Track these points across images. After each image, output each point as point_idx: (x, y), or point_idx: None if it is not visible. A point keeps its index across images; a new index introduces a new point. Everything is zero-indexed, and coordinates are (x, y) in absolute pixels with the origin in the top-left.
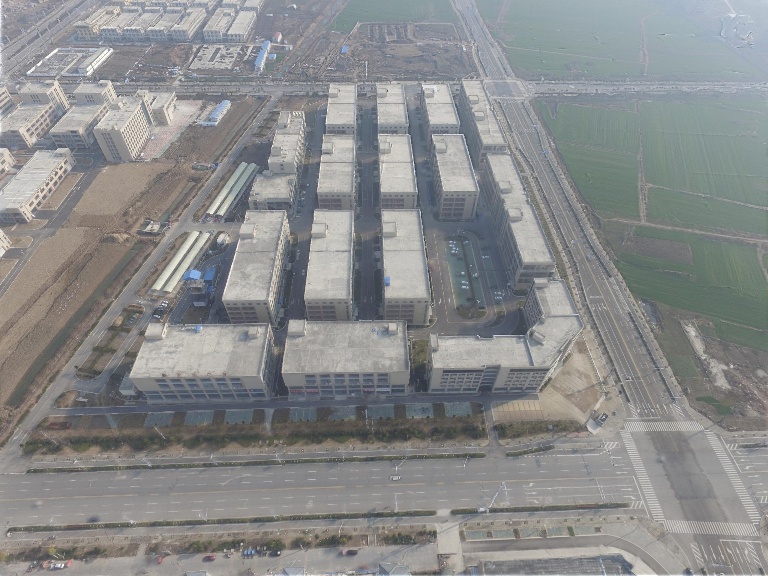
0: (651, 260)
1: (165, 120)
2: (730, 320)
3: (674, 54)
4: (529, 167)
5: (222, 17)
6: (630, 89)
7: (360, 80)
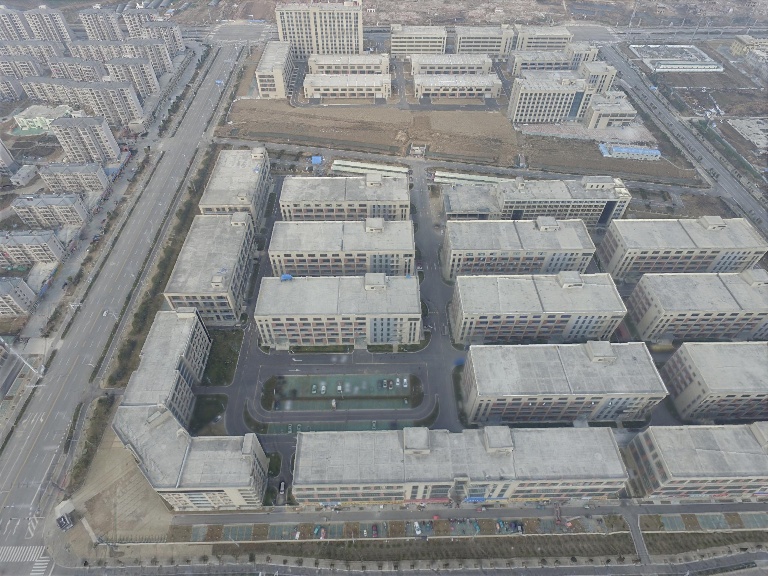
0: None
1: (589, 122)
2: None
3: None
4: (679, 568)
5: None
6: None
7: None
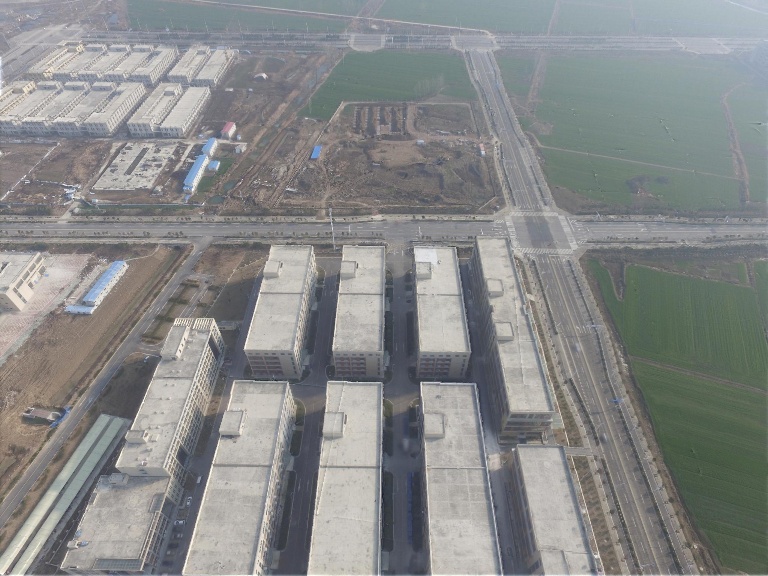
0: None
1: (13, 305)
2: None
3: None
4: (588, 429)
5: (162, 98)
6: (733, 237)
7: None
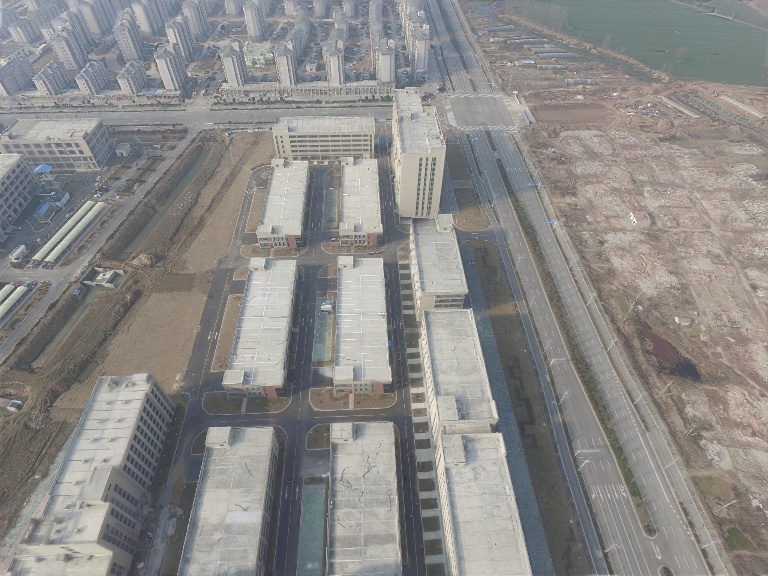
0: None
1: None
2: None
3: None
4: None
5: None
6: None
7: None
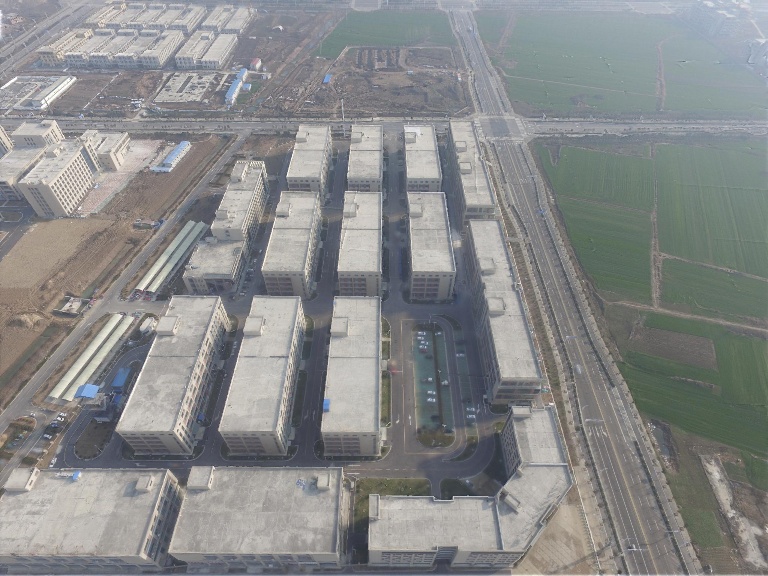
0: (664, 363)
1: (113, 165)
2: (765, 456)
3: (695, 85)
4: (522, 229)
5: (199, 41)
6: (644, 129)
7: (339, 116)
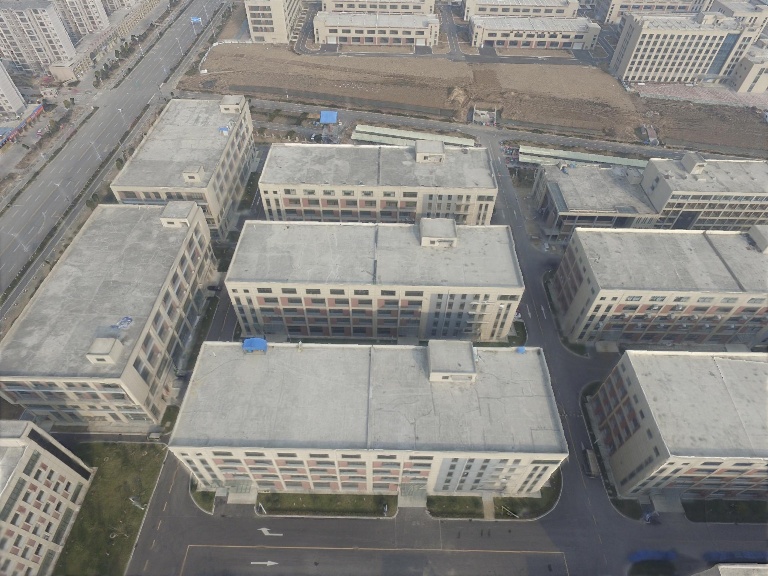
0: None
1: (741, 82)
2: None
3: None
4: None
5: None
6: None
7: None
